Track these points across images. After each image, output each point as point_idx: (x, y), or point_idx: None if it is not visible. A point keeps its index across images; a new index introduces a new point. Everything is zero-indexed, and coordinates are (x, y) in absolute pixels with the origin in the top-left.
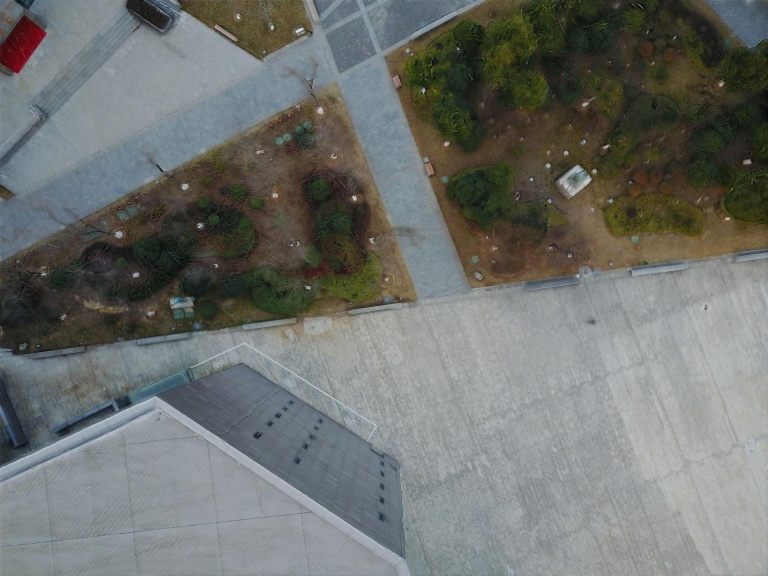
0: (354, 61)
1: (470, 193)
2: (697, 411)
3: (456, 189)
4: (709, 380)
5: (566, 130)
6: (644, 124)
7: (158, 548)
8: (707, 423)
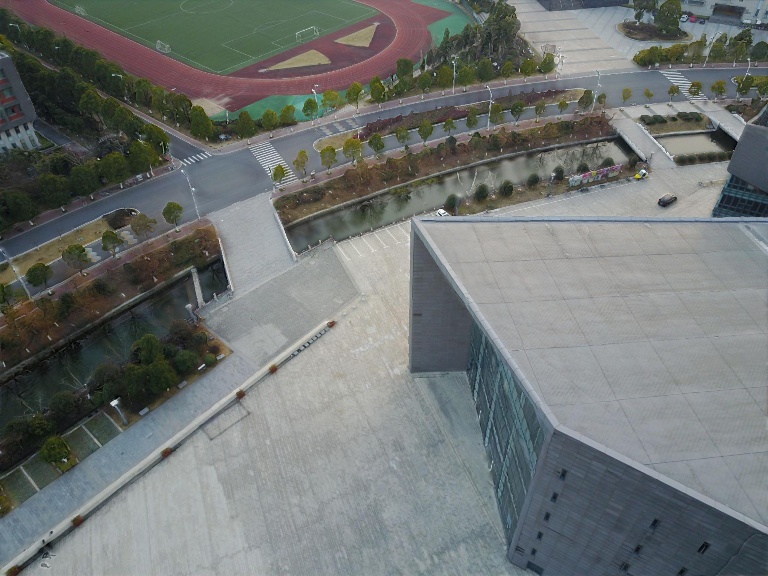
0: None
1: None
2: None
3: None
4: None
5: None
6: None
7: (762, 437)
8: None
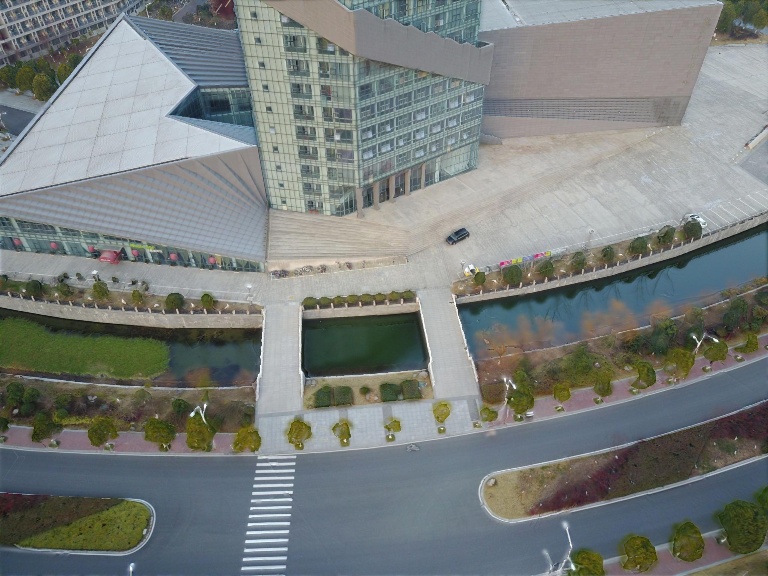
0: None
1: None
2: (730, 69)
3: None
4: (731, 64)
5: None
6: None
7: None
8: (736, 71)
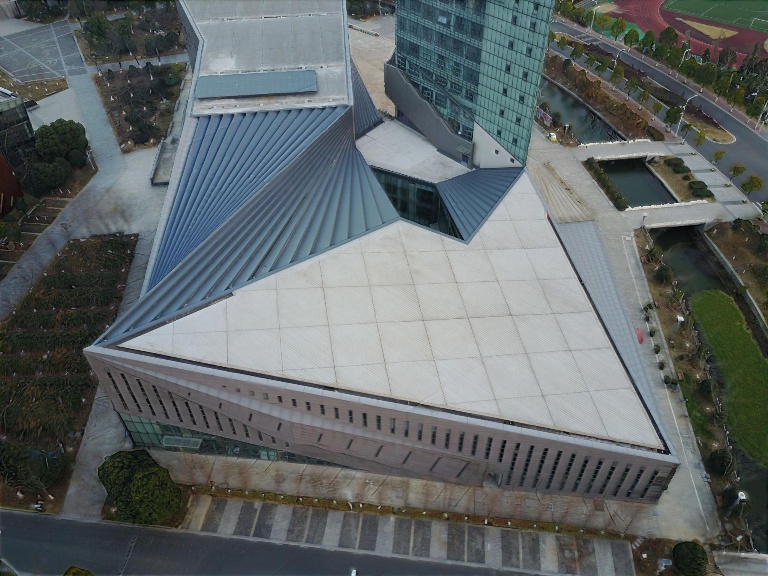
0: (85, 71)
1: (151, 41)
2: None
3: (149, 47)
4: None
5: (140, 37)
6: (146, 25)
7: None
8: None
